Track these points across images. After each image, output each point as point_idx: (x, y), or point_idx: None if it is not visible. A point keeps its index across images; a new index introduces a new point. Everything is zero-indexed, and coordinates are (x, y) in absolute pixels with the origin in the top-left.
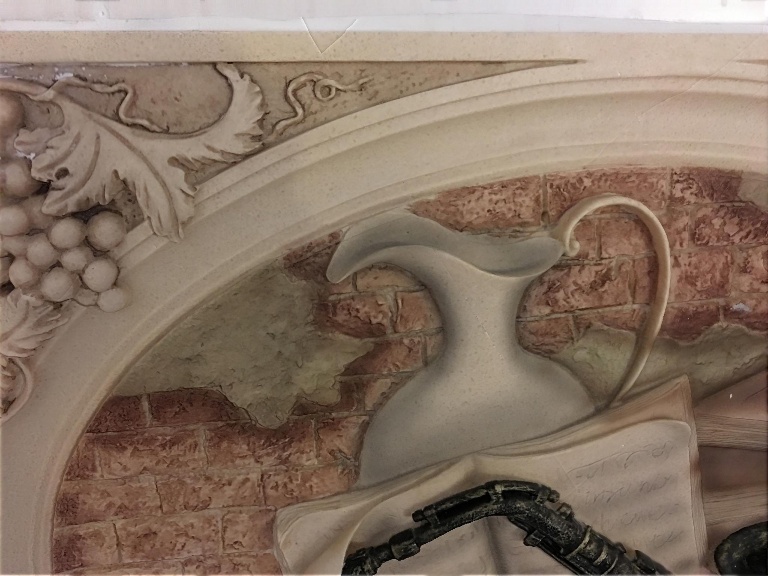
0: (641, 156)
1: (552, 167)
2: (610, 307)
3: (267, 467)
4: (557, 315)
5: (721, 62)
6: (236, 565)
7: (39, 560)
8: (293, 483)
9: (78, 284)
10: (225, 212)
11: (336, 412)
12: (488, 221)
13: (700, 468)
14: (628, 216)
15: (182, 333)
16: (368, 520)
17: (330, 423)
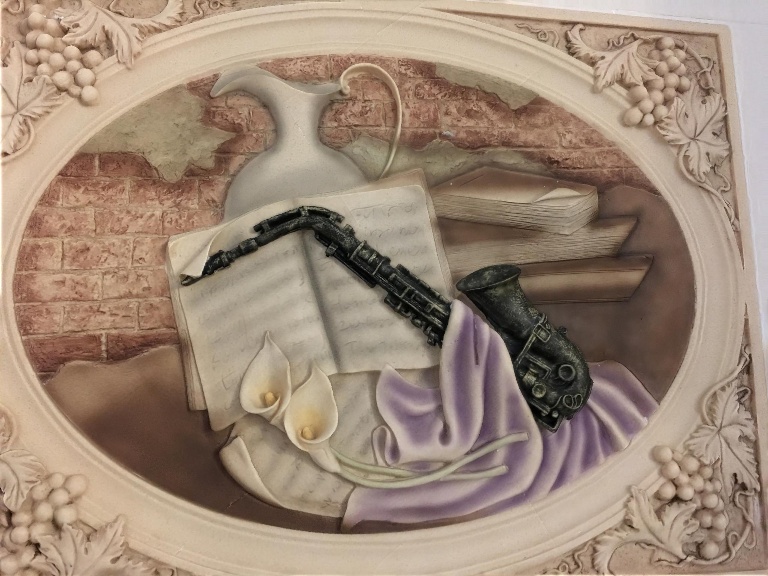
0: (380, 50)
1: (333, 52)
2: (373, 127)
3: (166, 208)
4: (342, 128)
5: (412, 7)
6: (139, 276)
7: (8, 262)
8: (182, 219)
9: (72, 81)
10: (158, 57)
11: (212, 176)
12: (300, 75)
13: (440, 229)
14: (378, 81)
15: (125, 118)
16: (227, 236)
17: (207, 181)
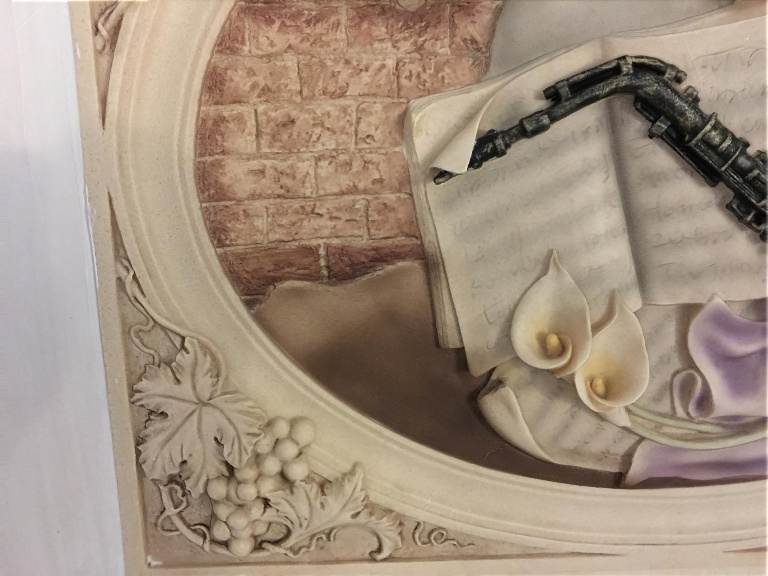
0: None
1: None
2: None
3: (403, 54)
4: None
5: None
6: (366, 163)
7: (184, 143)
8: (426, 73)
9: None
10: None
11: None
12: None
13: None
14: None
15: None
16: (499, 103)
17: (465, 6)
